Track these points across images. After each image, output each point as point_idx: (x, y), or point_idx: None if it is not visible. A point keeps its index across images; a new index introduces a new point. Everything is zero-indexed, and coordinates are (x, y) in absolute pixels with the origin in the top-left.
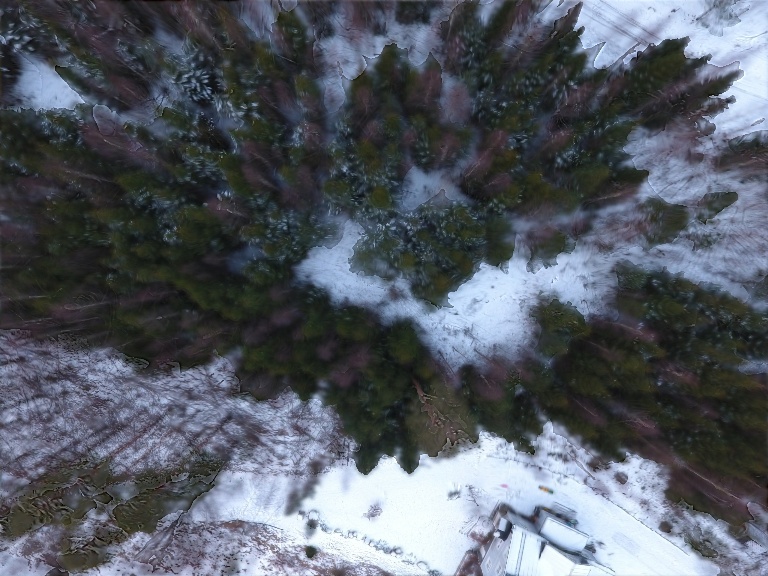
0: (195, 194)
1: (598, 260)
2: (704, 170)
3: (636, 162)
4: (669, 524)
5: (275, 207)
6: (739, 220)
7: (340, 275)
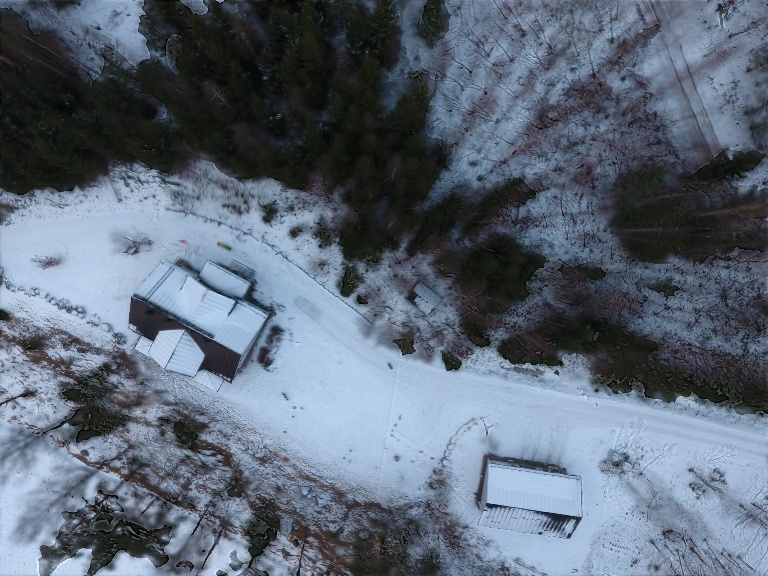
0: None
1: None
2: None
3: None
4: None
5: None
6: None
7: None
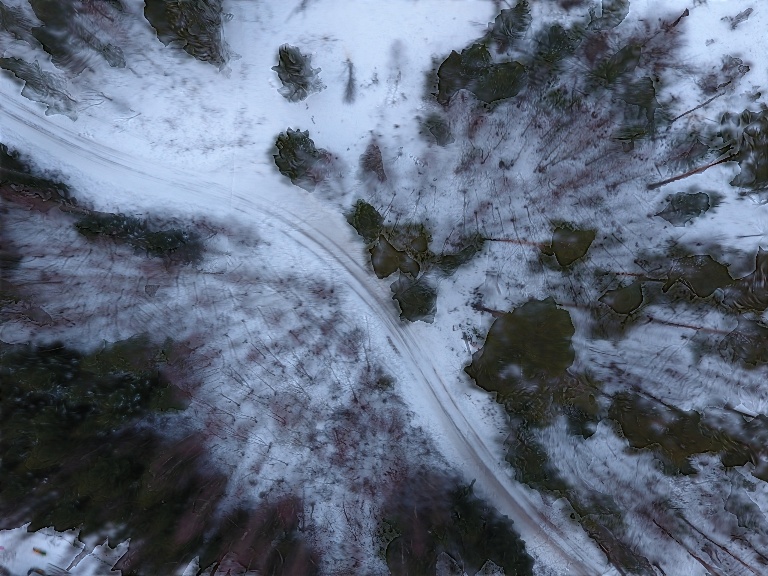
0: None
1: (14, 330)
2: (105, 243)
3: (38, 237)
4: None
5: None
6: (143, 289)
7: None
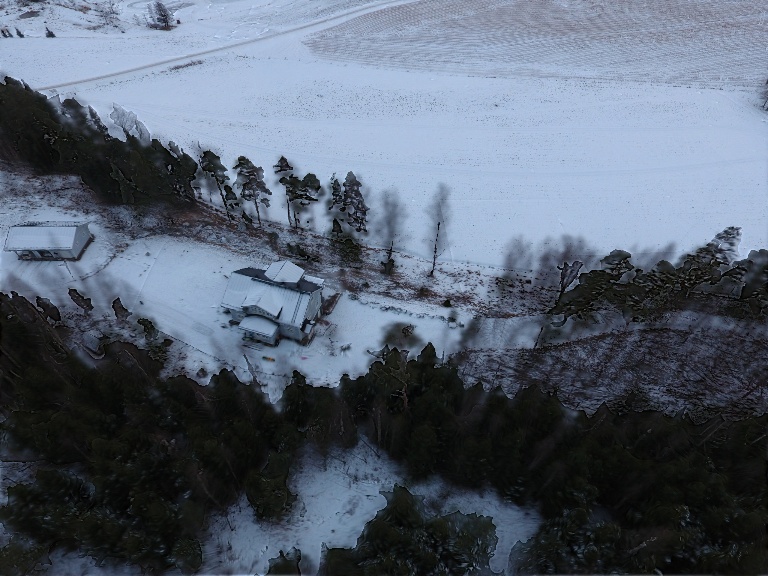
0: (685, 575)
1: None
2: None
3: None
4: (164, 345)
5: (596, 575)
6: None
7: (495, 521)
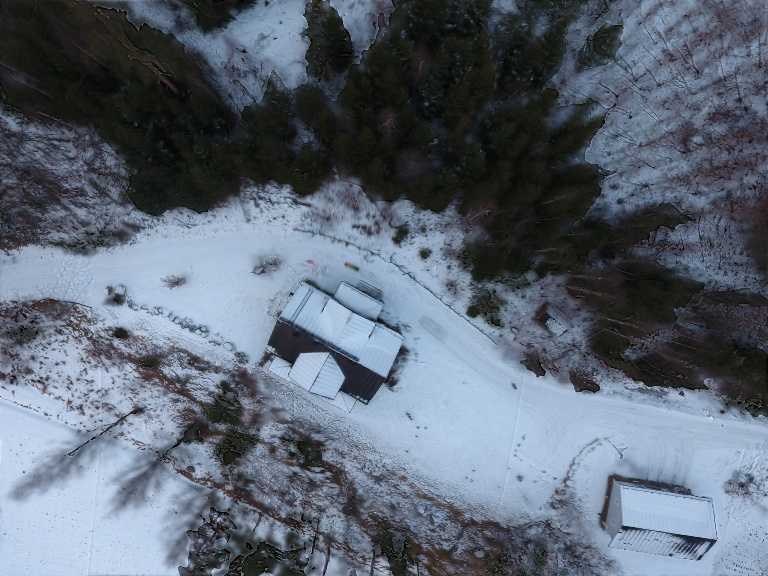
0: None
1: None
2: None
3: None
4: (476, 308)
5: None
6: None
7: (125, 3)
